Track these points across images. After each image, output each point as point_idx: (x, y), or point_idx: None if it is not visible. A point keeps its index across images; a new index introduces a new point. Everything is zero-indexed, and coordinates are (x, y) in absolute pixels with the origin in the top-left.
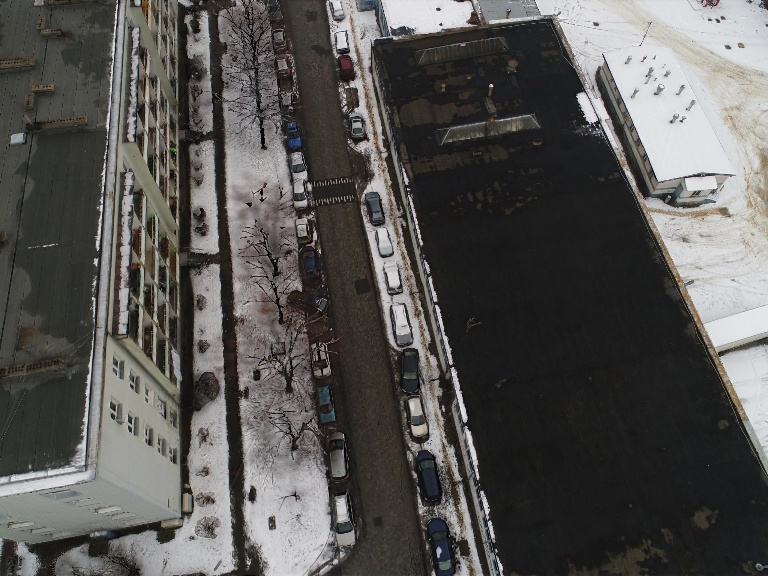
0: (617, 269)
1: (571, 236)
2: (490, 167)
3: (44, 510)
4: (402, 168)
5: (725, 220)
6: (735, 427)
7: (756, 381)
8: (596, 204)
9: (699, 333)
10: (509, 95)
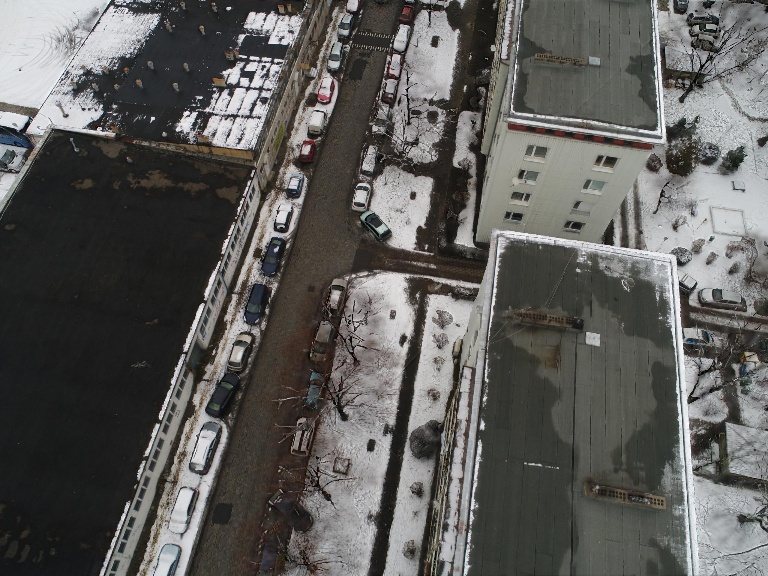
0: None
1: None
2: None
3: None
4: None
5: None
6: (4, 222)
7: None
8: None
9: None
10: None
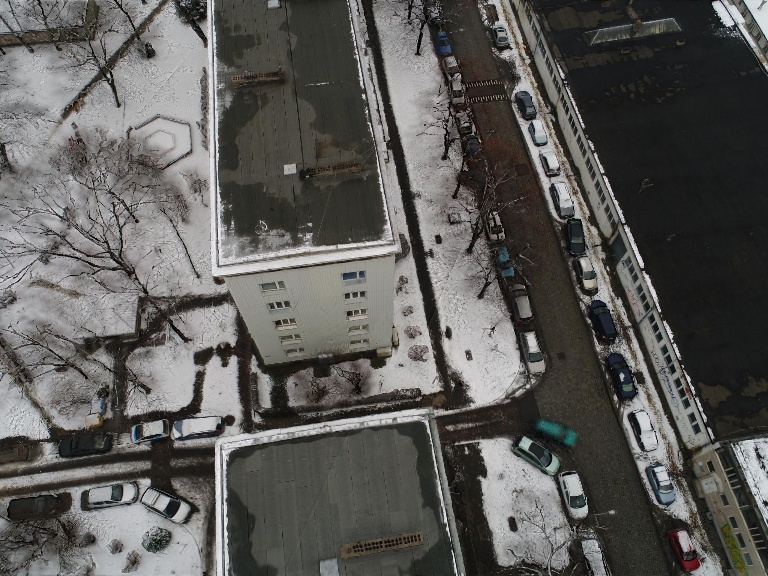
0: (766, 146)
1: (720, 120)
2: (638, 63)
3: (321, 304)
4: (557, 65)
5: None
6: None
7: None
8: (740, 94)
9: None
10: (648, 3)
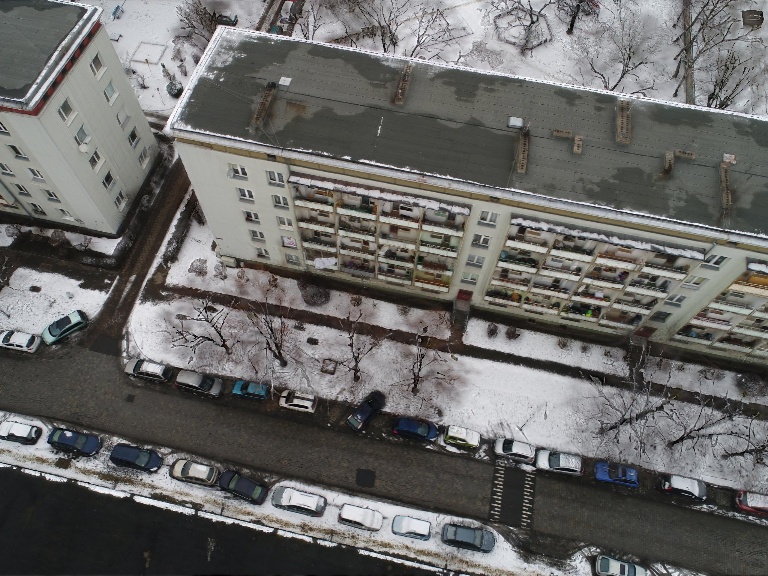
0: None
1: None
2: None
3: None
4: None
5: None
6: None
7: None
8: None
9: None
10: None
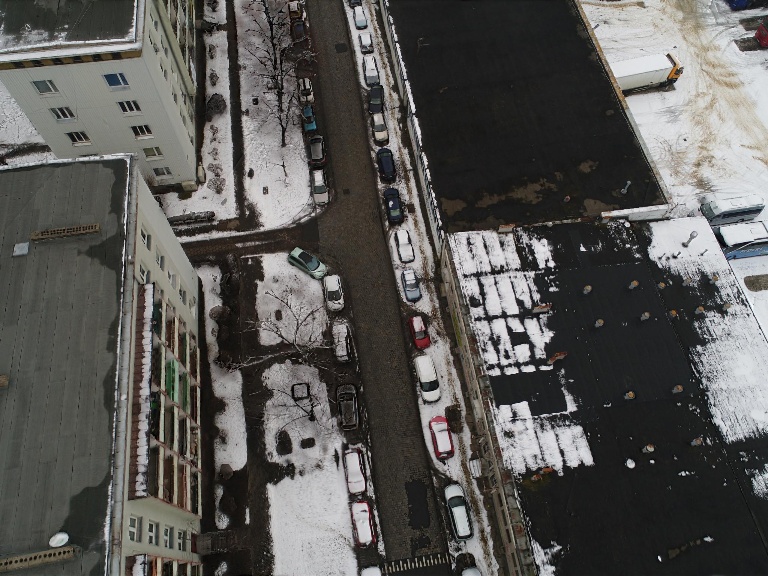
0: (541, 19)
1: None
2: None
3: (101, 115)
4: None
5: (641, 10)
6: (619, 114)
7: (650, 113)
8: None
9: (599, 58)
10: None
